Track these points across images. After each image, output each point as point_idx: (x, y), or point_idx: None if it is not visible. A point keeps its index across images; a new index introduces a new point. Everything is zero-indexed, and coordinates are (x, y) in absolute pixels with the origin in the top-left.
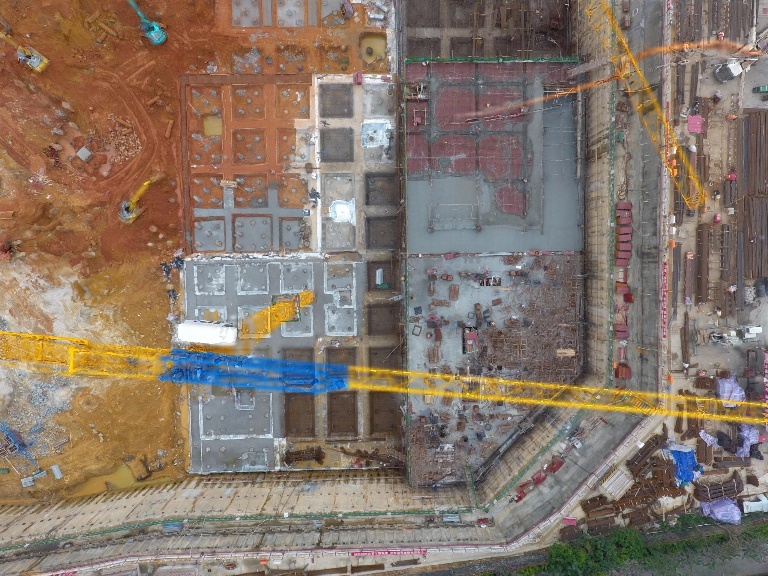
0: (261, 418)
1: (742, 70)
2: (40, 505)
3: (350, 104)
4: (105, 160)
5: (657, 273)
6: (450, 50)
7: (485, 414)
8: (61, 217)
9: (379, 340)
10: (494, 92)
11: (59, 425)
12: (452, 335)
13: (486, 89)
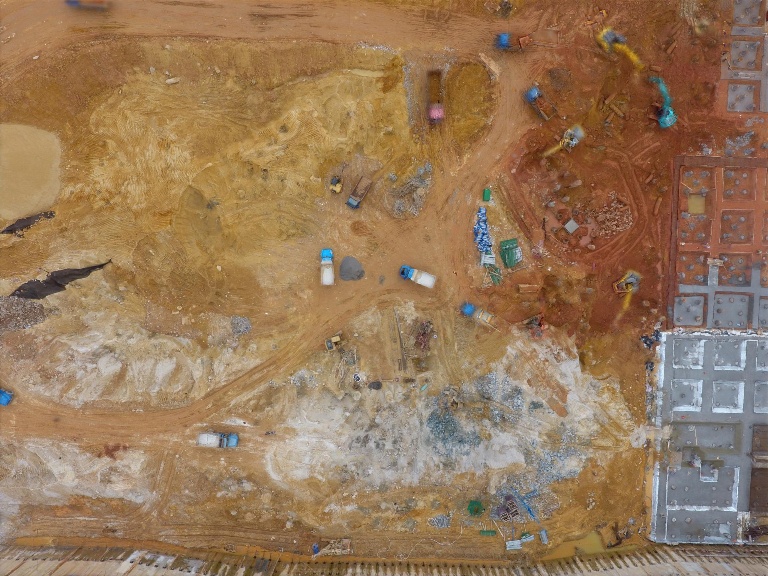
0: (724, 491)
1: None
2: (520, 568)
3: None
4: (587, 232)
5: None
6: None
7: None
8: (560, 289)
9: None
10: None
11: (553, 492)
12: None
13: None
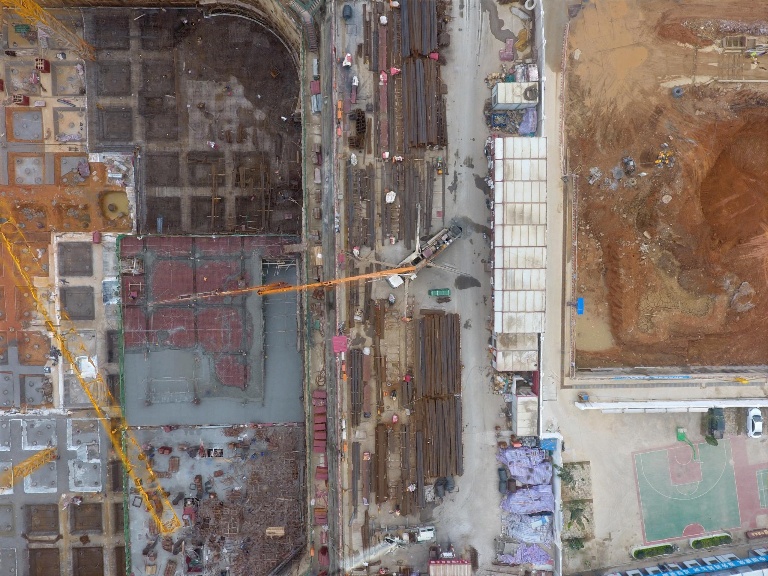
0: (7, 572)
1: (403, 281)
2: None
3: (91, 261)
4: None
5: (336, 472)
6: (191, 209)
7: None
8: None
9: None
10: (212, 265)
11: None
12: (174, 506)
13: (204, 262)
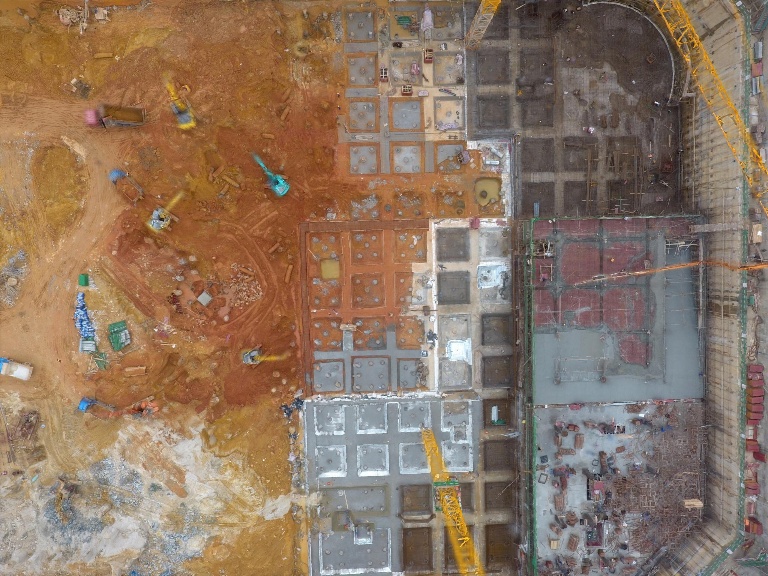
0: (379, 552)
1: None
2: None
3: (466, 247)
4: (224, 303)
5: None
6: (564, 194)
7: (611, 560)
8: (186, 365)
9: (495, 476)
10: (618, 247)
11: (188, 570)
12: (577, 482)
13: (610, 244)
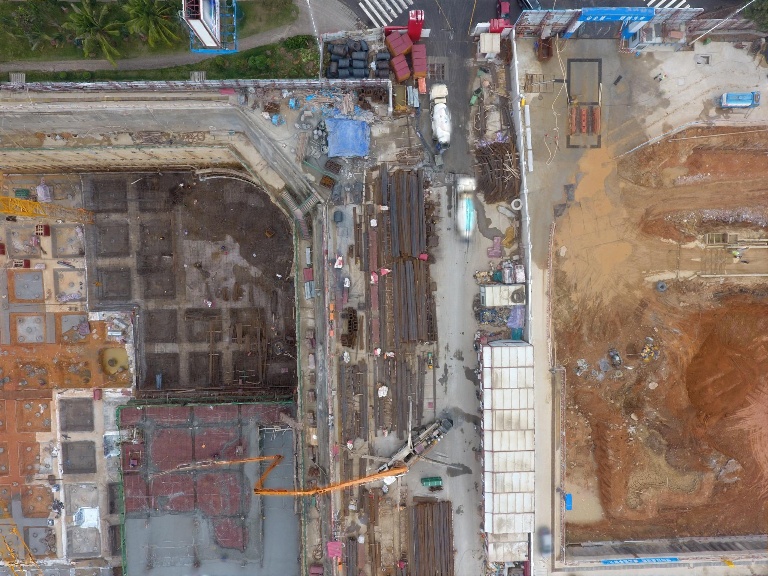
0: None
1: None
2: None
3: (92, 416)
4: None
5: None
6: (189, 364)
7: None
8: None
9: None
10: (210, 432)
11: None
12: None
13: (202, 430)
